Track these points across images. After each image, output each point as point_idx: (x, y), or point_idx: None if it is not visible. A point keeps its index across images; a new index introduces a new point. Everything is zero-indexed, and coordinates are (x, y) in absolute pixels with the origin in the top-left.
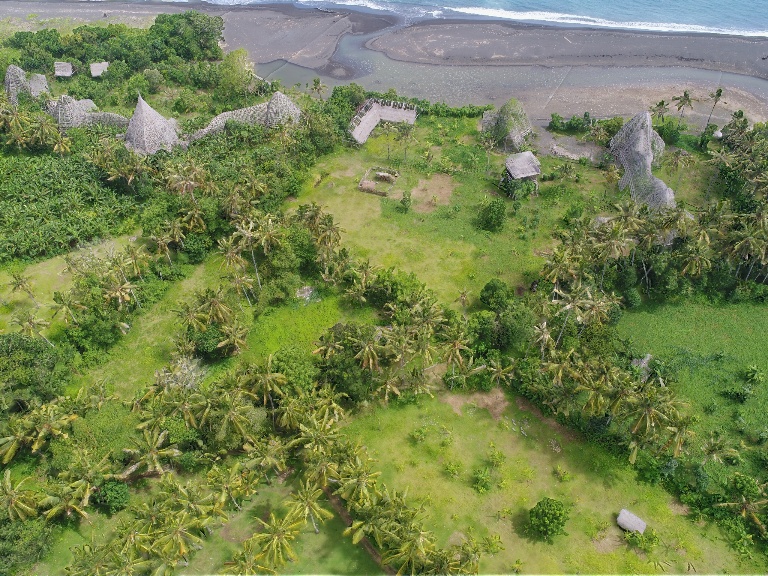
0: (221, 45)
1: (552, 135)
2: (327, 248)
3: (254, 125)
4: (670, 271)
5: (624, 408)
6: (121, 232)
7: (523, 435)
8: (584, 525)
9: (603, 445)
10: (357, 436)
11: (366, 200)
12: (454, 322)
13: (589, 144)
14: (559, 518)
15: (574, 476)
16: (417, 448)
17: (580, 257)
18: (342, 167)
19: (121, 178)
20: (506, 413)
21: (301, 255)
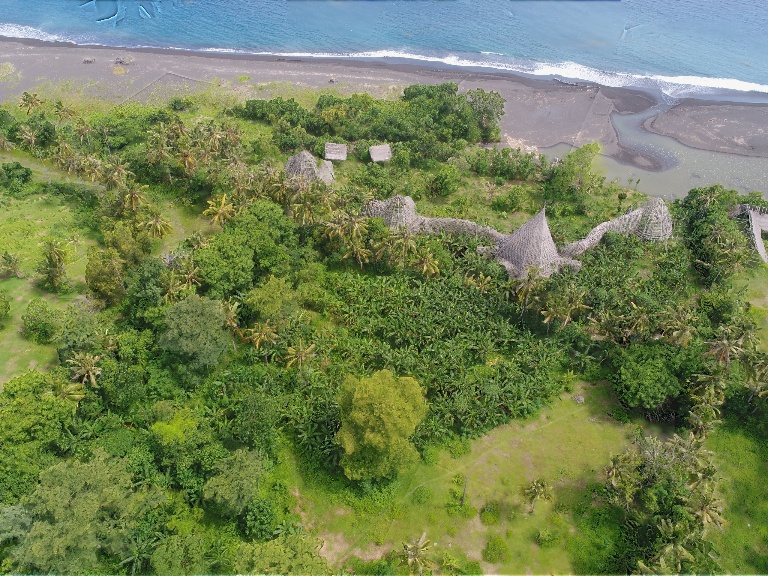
0: None
1: None
2: None
3: (624, 235)
4: None
5: None
6: (557, 388)
7: None
8: None
9: None
10: None
11: None
12: None
13: None
14: None
15: None
16: None
17: None
18: (758, 294)
19: (532, 313)
20: None
21: None
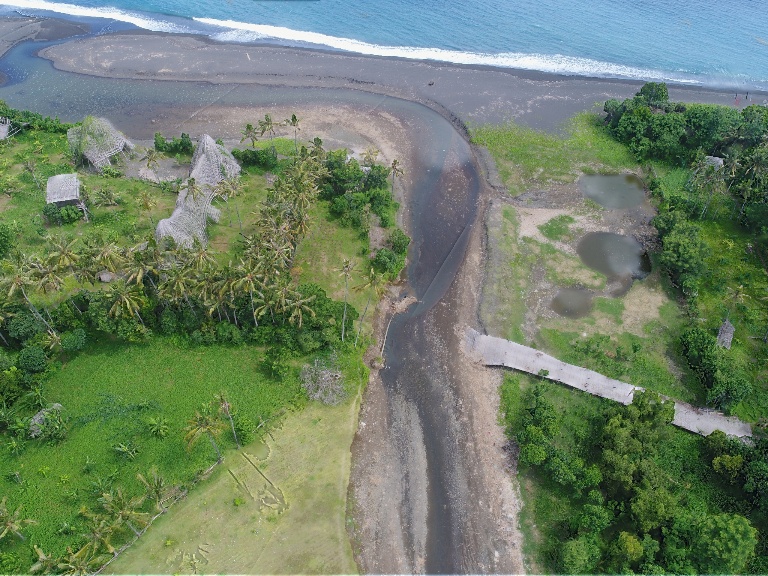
0: None
1: None
2: None
3: None
4: (99, 312)
5: None
6: None
7: None
8: None
9: None
10: None
11: None
12: None
13: (184, 167)
14: None
15: None
16: None
17: None
18: None
19: None
20: None
21: None
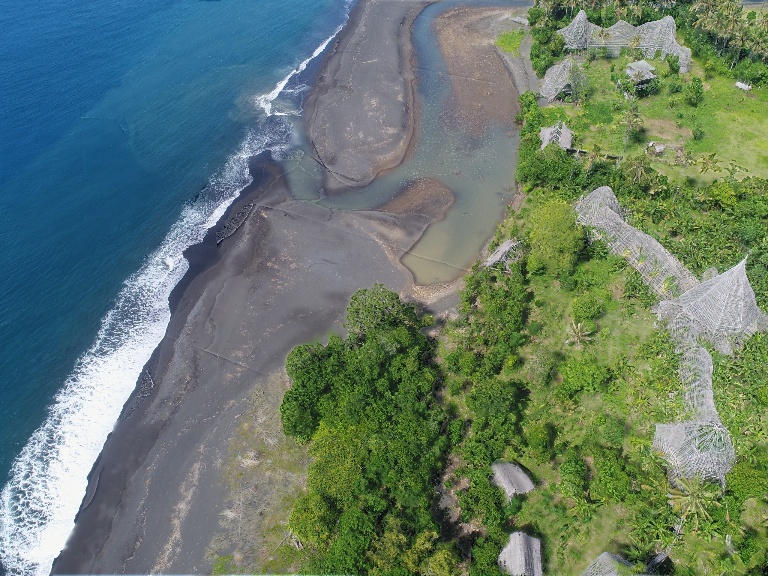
0: None
1: None
2: None
3: None
4: None
5: None
6: None
7: None
8: None
9: None
10: None
11: None
12: None
13: (560, 63)
14: None
15: None
16: None
17: None
18: None
19: None
20: None
21: None
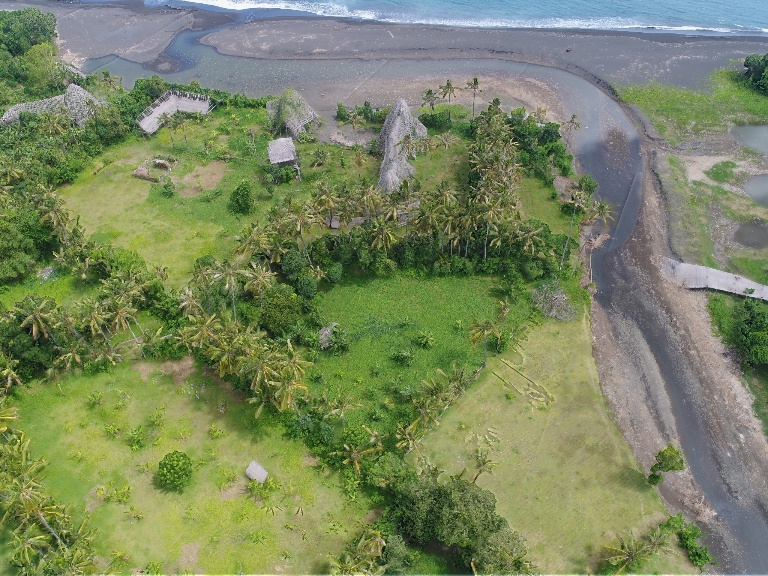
0: (59, 41)
1: (337, 124)
2: (62, 229)
3: None
4: (361, 245)
5: (247, 367)
6: None
7: (196, 398)
8: (218, 476)
9: (264, 405)
10: (41, 402)
11: (138, 186)
12: (161, 296)
13: (368, 132)
14: (175, 468)
15: (224, 433)
16: (93, 411)
17: (274, 233)
18: (127, 155)
19: None
20: (188, 378)
21: (32, 236)
